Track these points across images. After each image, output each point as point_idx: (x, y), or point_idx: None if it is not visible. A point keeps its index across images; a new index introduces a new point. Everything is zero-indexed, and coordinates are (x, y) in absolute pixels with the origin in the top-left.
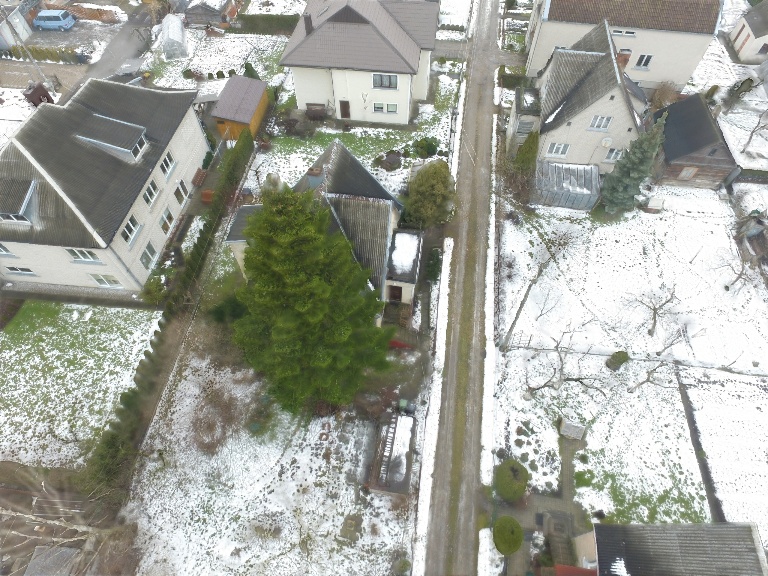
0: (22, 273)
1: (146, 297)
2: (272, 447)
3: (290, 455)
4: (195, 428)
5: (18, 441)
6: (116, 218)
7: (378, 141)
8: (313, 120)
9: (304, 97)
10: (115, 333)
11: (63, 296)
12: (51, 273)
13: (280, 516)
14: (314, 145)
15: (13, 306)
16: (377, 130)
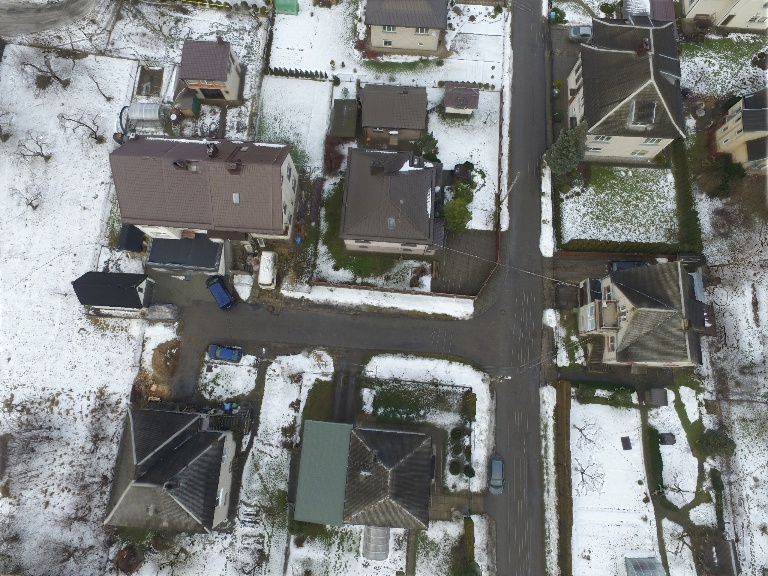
0: (590, 151)
1: (660, 162)
2: (756, 233)
3: (763, 236)
4: (713, 227)
5: (635, 236)
6: (682, 121)
7: (749, 45)
8: (702, 28)
9: (698, 10)
10: (651, 182)
11: (609, 163)
12: (612, 150)
13: (767, 261)
14: (707, 50)
15: (587, 170)
16: (746, 35)
